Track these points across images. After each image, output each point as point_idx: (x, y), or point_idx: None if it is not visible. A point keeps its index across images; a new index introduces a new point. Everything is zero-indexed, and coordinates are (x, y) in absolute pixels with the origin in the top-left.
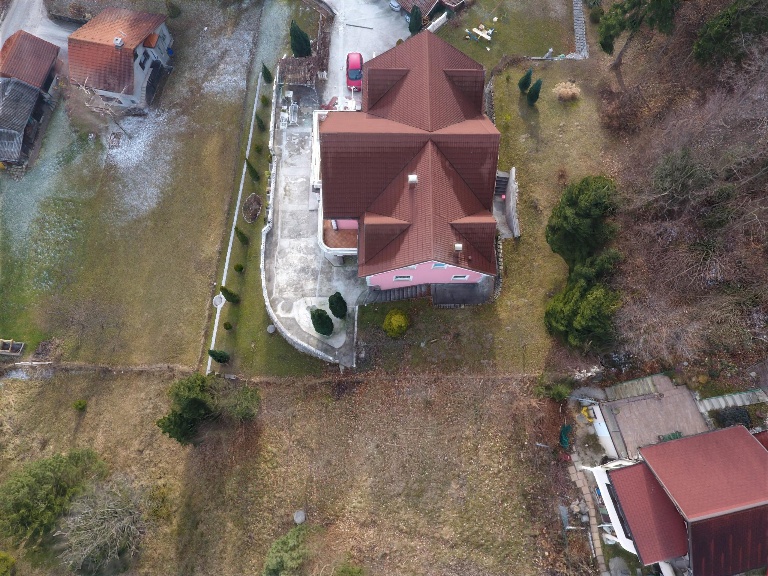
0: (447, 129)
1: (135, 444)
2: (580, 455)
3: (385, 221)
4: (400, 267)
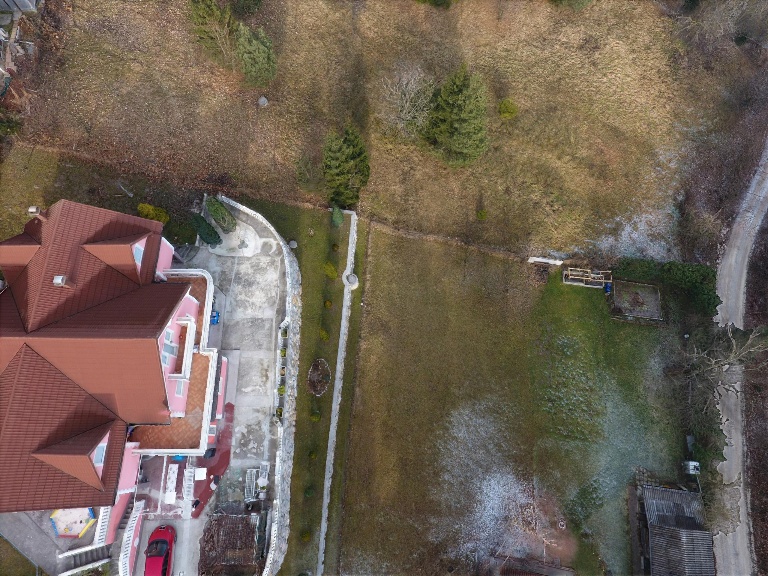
0: (7, 355)
1: (419, 175)
2: (3, 81)
3: (109, 251)
4: (106, 209)
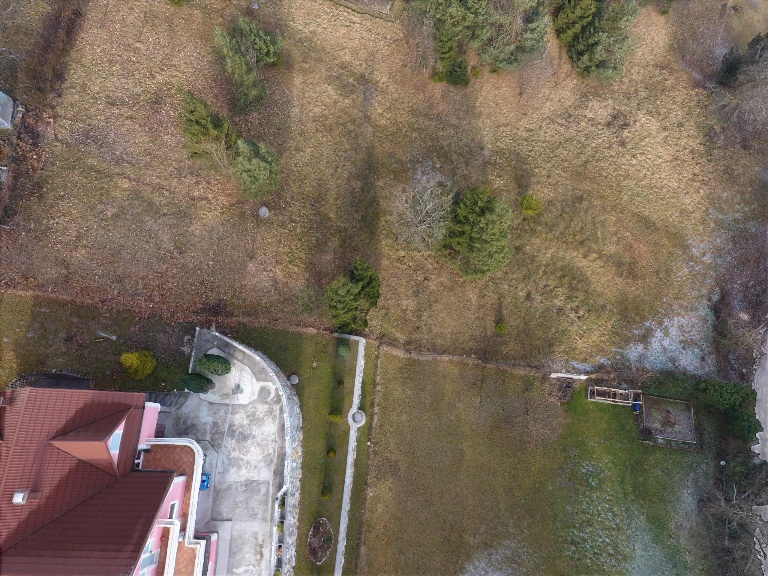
0: None
1: (433, 286)
2: None
3: (81, 448)
4: (79, 390)
